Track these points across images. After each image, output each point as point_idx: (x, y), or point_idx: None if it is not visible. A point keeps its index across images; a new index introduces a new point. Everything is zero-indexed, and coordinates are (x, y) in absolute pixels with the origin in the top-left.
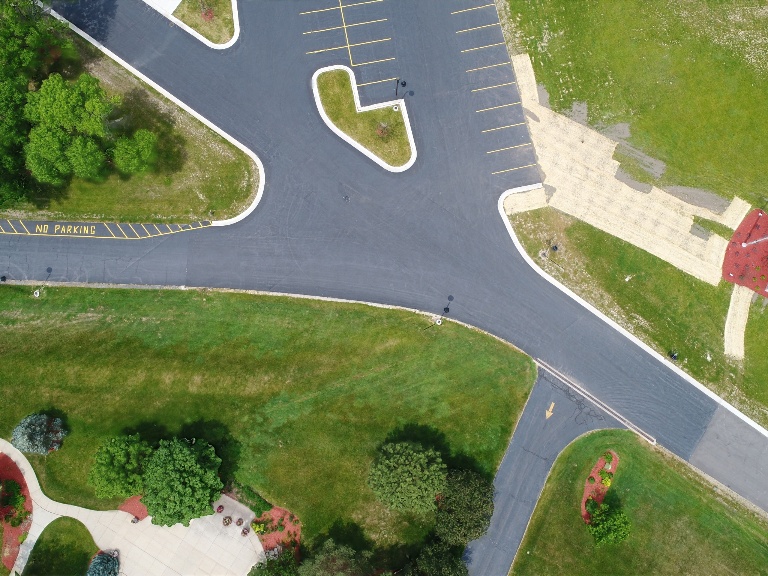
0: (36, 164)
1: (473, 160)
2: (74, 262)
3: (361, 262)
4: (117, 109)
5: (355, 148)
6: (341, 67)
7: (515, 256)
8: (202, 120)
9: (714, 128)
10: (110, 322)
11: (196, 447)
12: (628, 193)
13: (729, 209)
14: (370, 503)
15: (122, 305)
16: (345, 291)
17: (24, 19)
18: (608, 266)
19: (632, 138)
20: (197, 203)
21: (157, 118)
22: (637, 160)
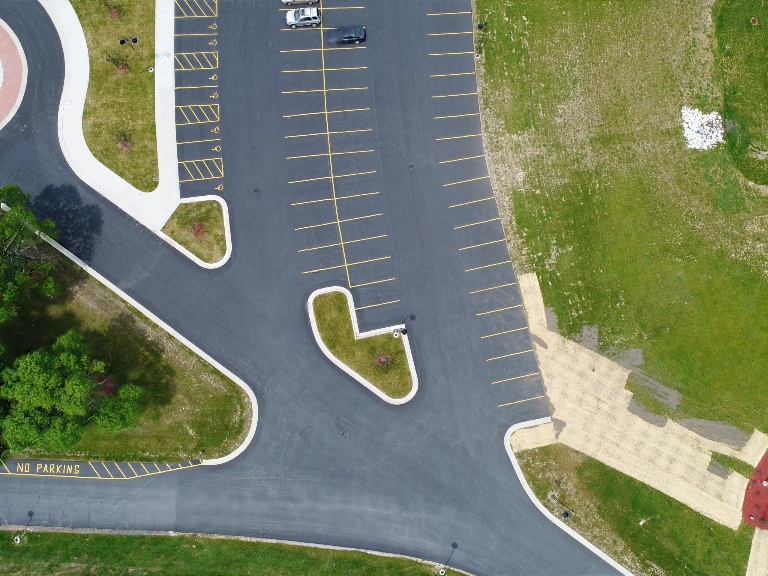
0: (13, 444)
1: (478, 391)
2: (57, 505)
3: (360, 505)
4: (103, 336)
5: (353, 378)
6: (338, 289)
7: (523, 498)
8: (192, 348)
9: (732, 353)
10: (94, 573)
11: None
12: (642, 427)
13: (749, 444)
14: None
15: (107, 553)
16: (343, 538)
17: (2, 276)
18: (621, 508)
19: (646, 365)
20: (187, 439)
21: (145, 346)
22: (651, 390)
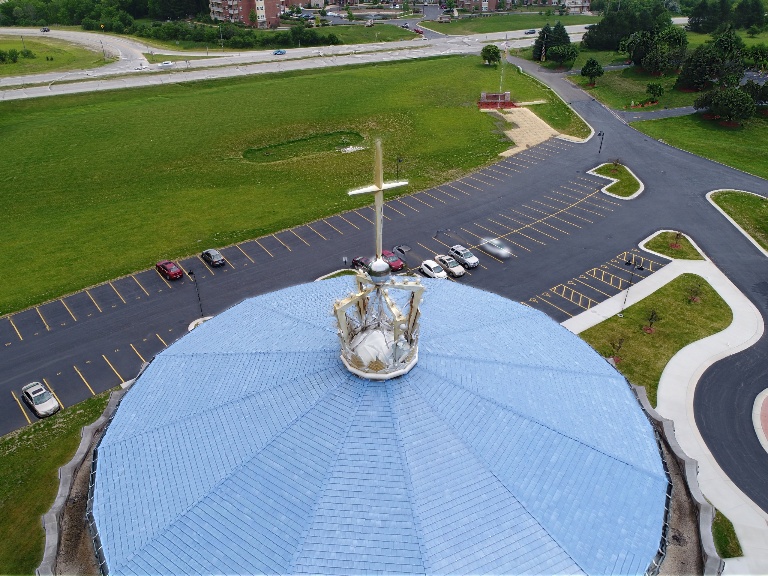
0: None
1: None
2: None
3: None
4: None
5: None
6: (606, 193)
7: None
8: (732, 220)
9: None
10: None
11: None
12: None
13: None
14: None
15: None
16: None
17: None
18: None
19: None
20: None
21: None
22: None
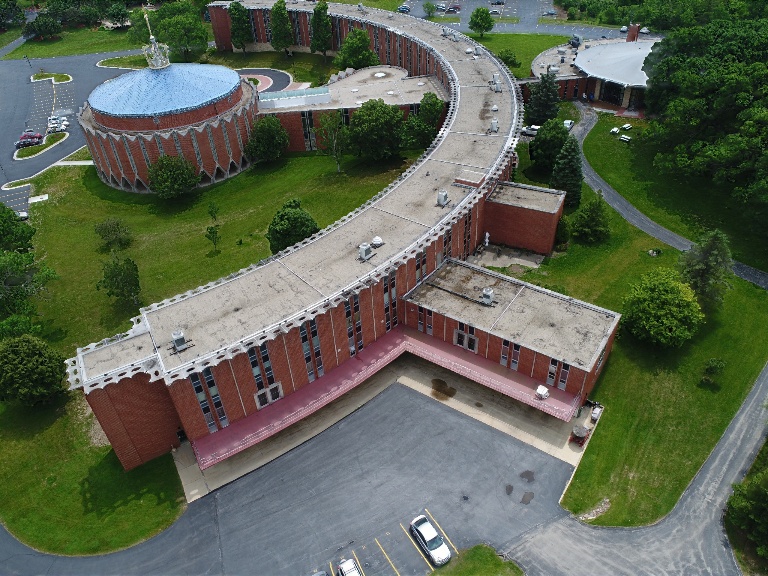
0: None
1: None
2: None
3: None
4: None
5: None
6: (58, 83)
7: None
8: None
9: None
10: None
11: (115, 20)
12: None
13: None
14: (66, 35)
15: None
16: None
17: None
18: None
19: None
20: None
21: None
22: None
